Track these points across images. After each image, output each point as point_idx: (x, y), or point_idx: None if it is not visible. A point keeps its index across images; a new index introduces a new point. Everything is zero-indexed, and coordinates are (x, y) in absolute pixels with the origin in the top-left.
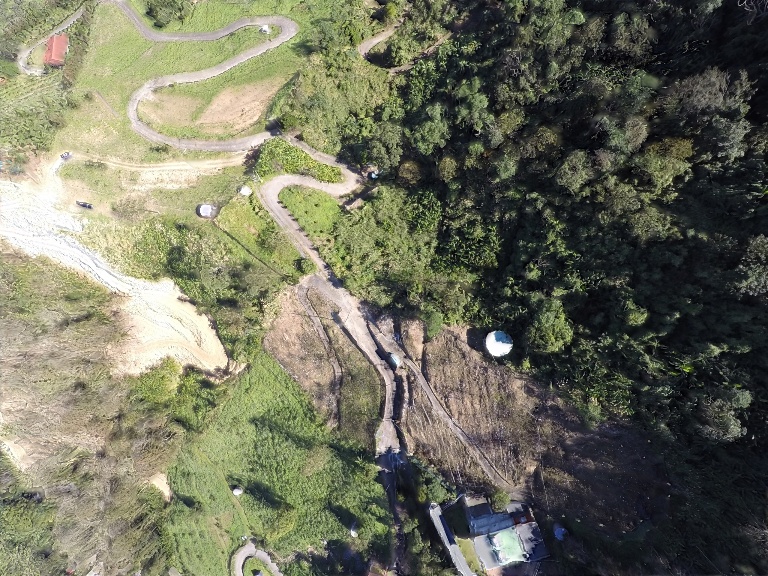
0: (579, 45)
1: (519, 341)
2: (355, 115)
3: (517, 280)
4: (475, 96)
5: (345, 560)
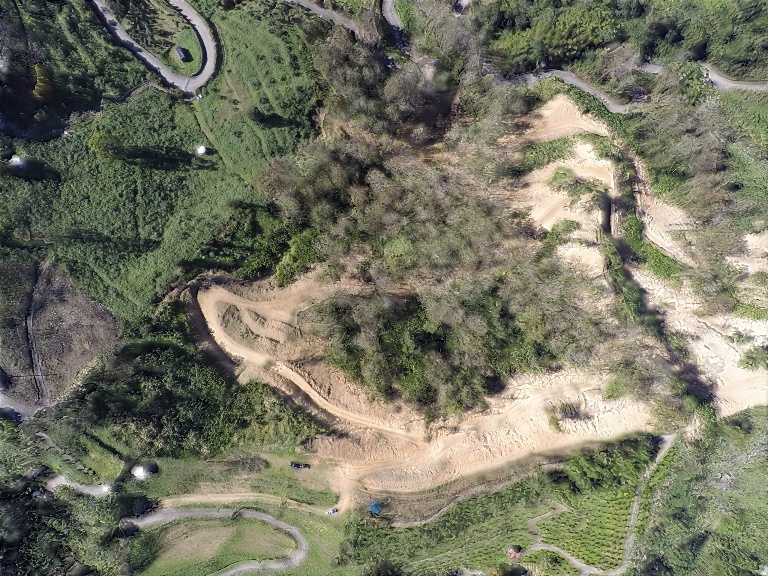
0: None
1: None
2: (79, 531)
3: None
4: None
5: (36, 123)
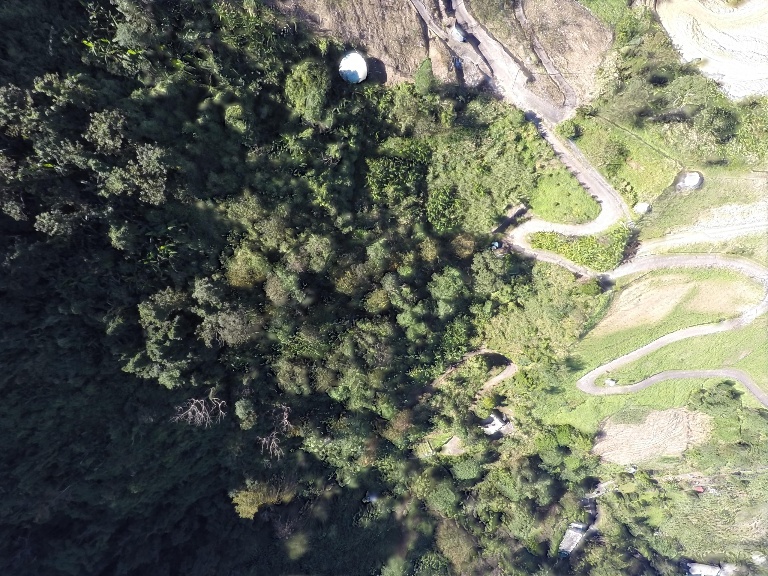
0: (329, 369)
1: (334, 76)
2: (518, 305)
3: (346, 145)
4: (410, 323)
5: None
